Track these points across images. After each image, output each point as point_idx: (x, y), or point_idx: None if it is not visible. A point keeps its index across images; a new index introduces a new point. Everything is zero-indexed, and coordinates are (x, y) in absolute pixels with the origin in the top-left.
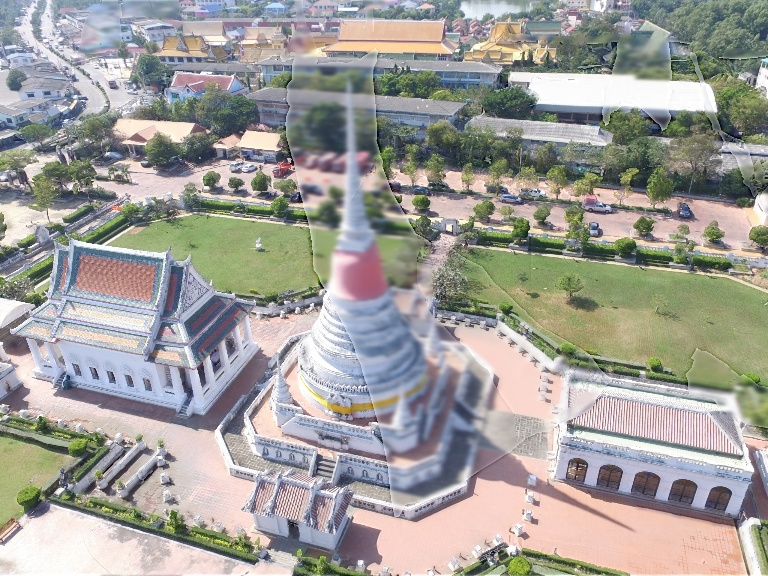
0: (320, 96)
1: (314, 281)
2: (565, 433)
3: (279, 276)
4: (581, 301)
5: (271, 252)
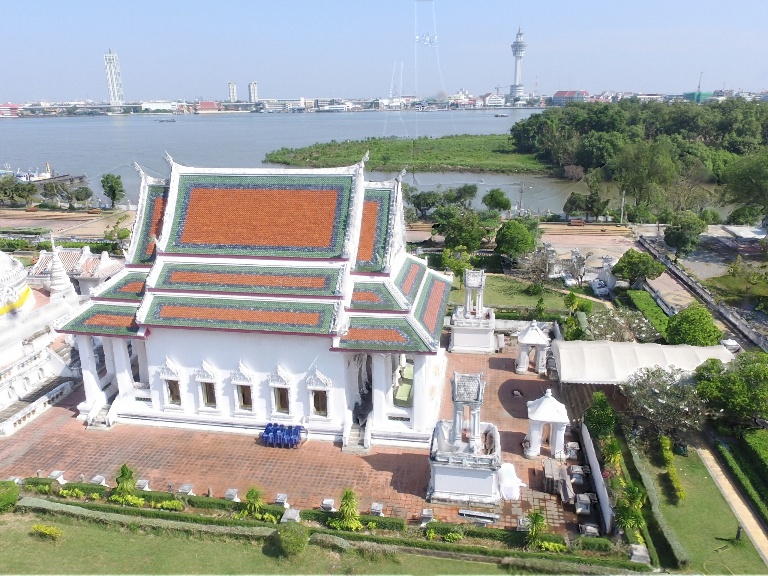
0: None
1: None
2: None
3: None
4: None
5: None
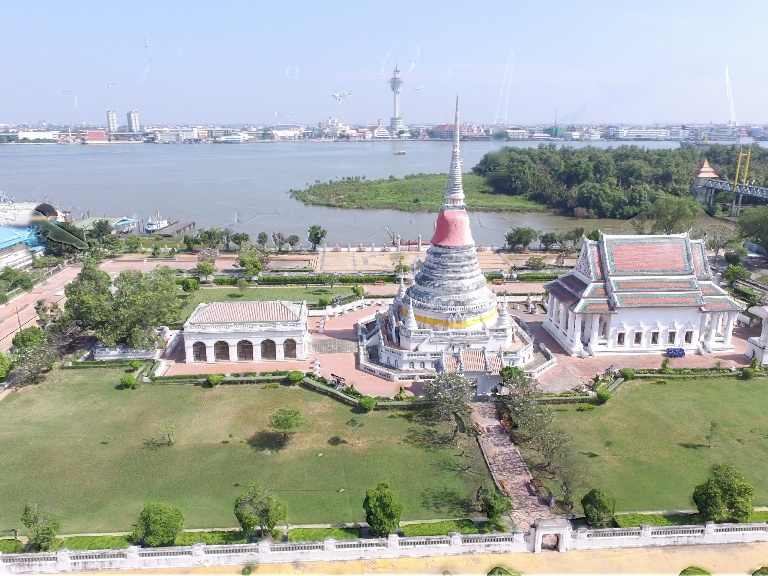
0: (370, 72)
1: (626, 407)
2: (305, 301)
3: (676, 405)
4: (271, 442)
5: (760, 436)
